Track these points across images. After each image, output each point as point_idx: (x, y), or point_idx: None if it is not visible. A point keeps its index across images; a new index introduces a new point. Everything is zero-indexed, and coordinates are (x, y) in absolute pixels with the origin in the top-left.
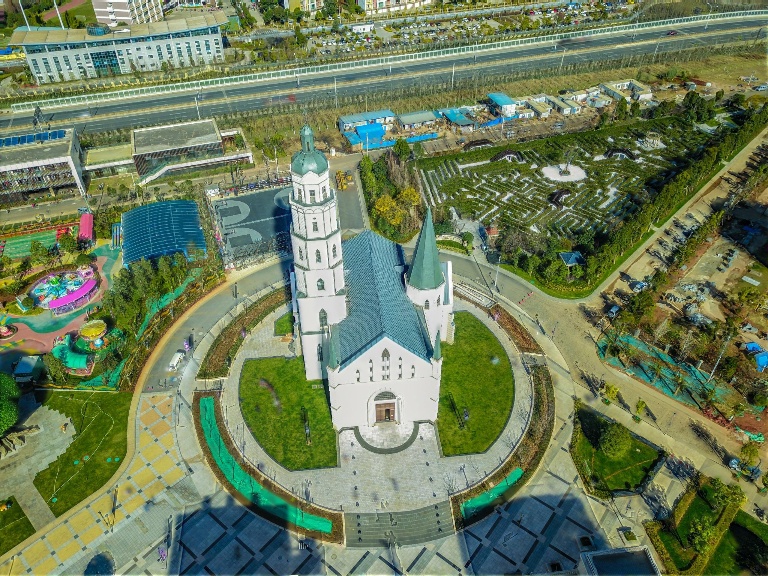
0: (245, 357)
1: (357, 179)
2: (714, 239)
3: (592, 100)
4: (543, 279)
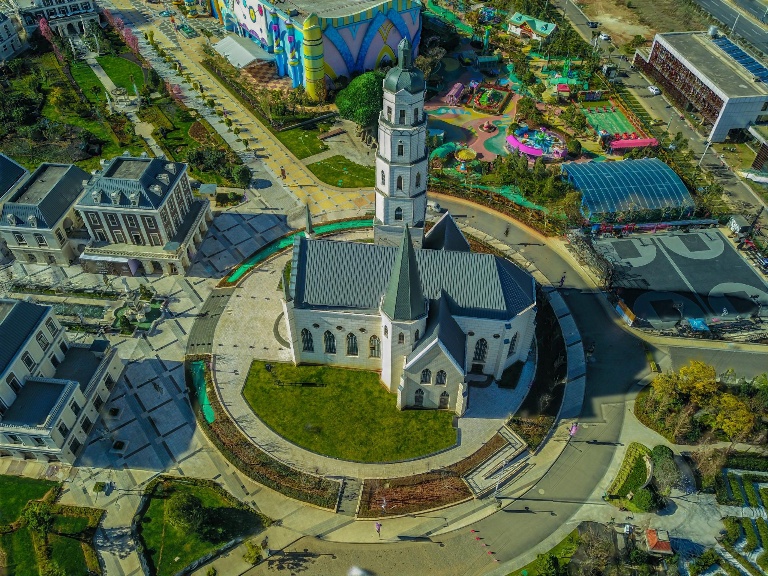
0: None
1: None
2: None
3: None
4: None
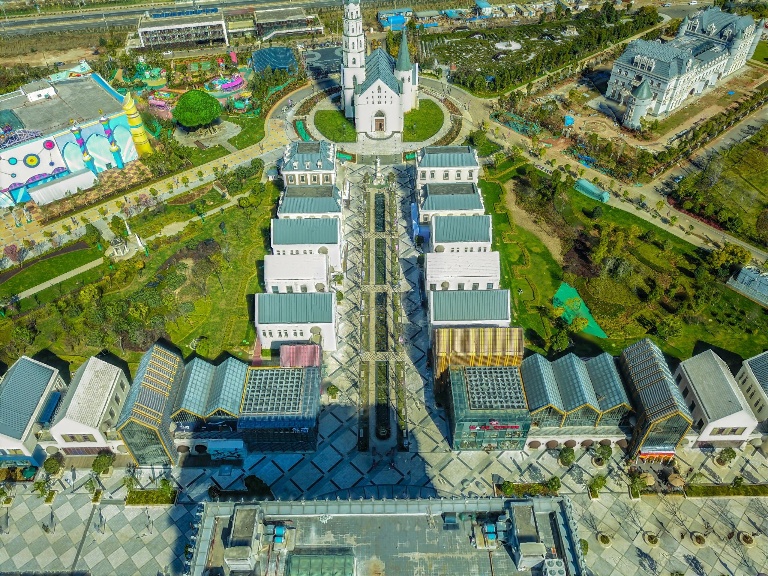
0: (317, 110)
1: (384, 44)
2: (578, 78)
3: (545, 8)
4: (474, 89)
